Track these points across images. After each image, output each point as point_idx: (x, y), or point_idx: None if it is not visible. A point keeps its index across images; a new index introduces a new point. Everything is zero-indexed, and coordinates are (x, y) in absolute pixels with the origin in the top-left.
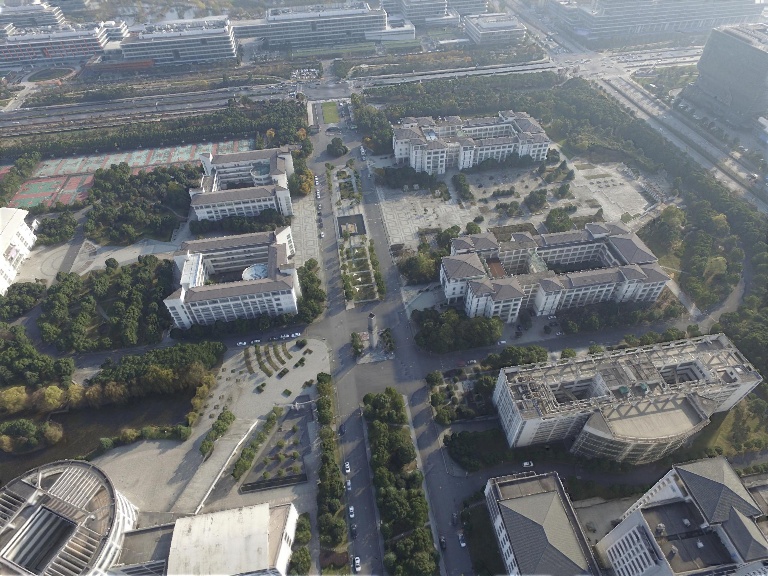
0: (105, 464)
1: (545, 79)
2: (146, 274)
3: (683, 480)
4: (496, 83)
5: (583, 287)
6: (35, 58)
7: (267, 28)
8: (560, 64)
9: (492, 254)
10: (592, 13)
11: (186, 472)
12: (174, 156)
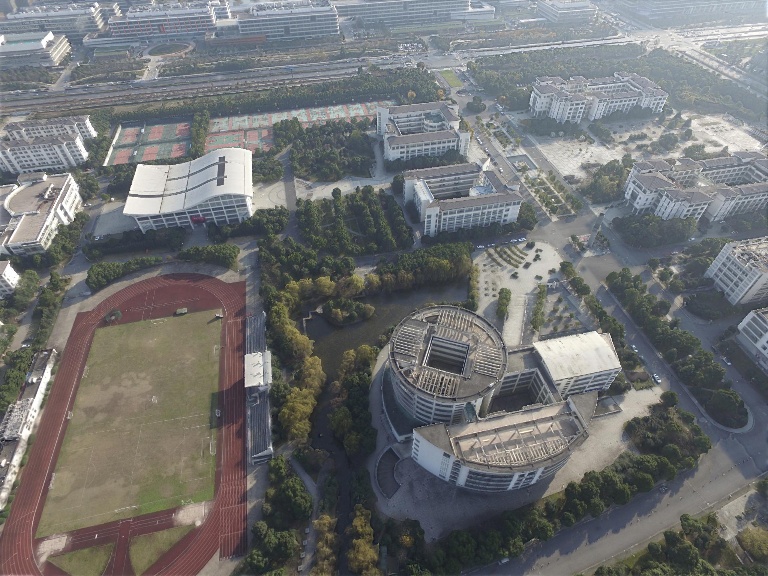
0: None
1: (632, 50)
2: None
3: None
4: (591, 53)
5: (751, 195)
6: (151, 34)
7: (364, 7)
8: (635, 39)
9: (668, 174)
10: None
11: None
12: (331, 114)
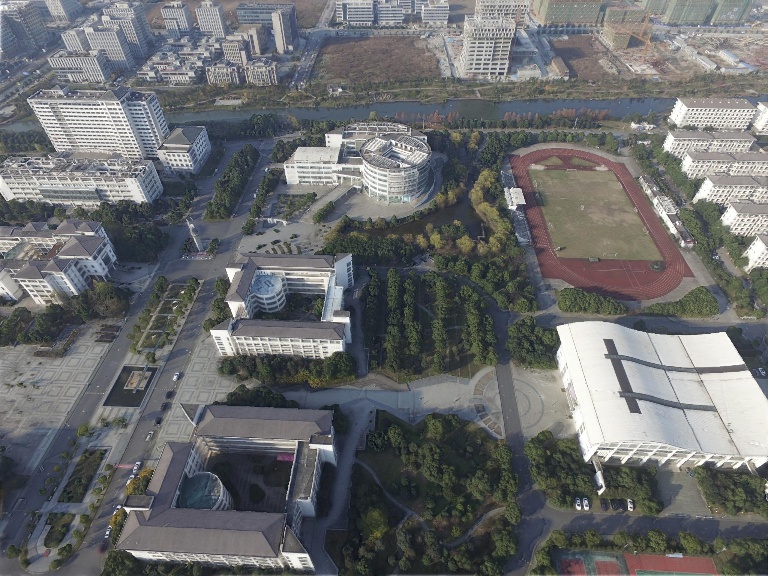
0: None
1: None
2: None
3: (121, 98)
4: None
5: None
6: None
7: None
8: None
9: None
10: None
11: (345, 207)
12: None
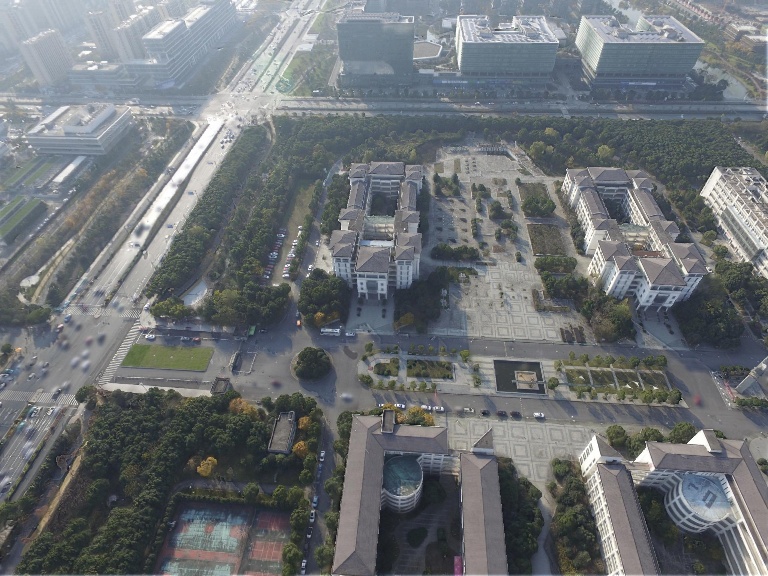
0: None
1: (262, 135)
2: None
3: None
4: (243, 168)
5: None
6: None
7: None
8: None
9: None
10: (153, 63)
11: None
12: None
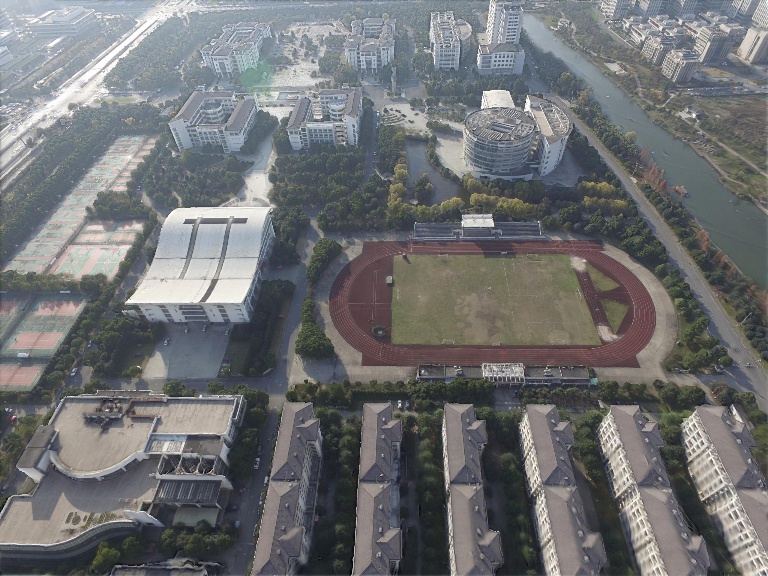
0: (446, 162)
1: (179, 21)
2: None
3: (500, 2)
4: (164, 34)
5: None
6: None
7: None
8: None
9: None
10: None
11: (455, 138)
12: (104, 176)
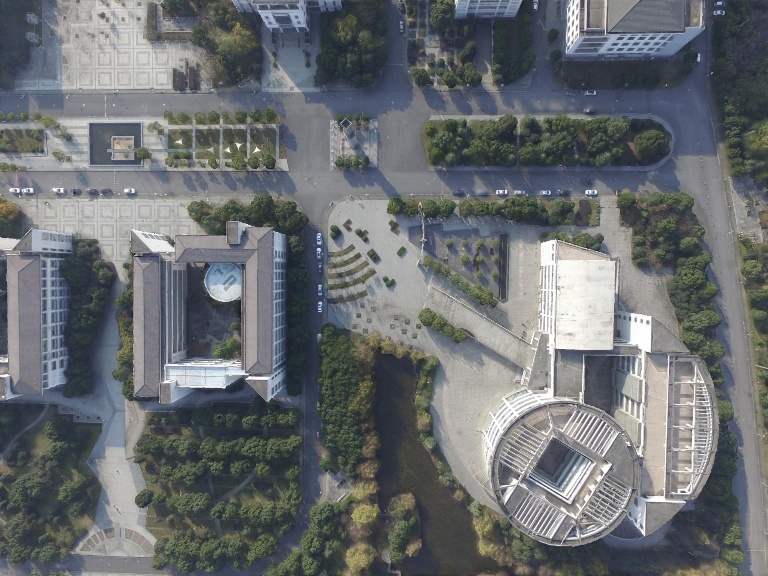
0: (450, 440)
1: None
2: (179, 444)
3: None
4: None
5: None
6: None
7: None
8: None
9: None
10: None
11: (474, 357)
12: None
